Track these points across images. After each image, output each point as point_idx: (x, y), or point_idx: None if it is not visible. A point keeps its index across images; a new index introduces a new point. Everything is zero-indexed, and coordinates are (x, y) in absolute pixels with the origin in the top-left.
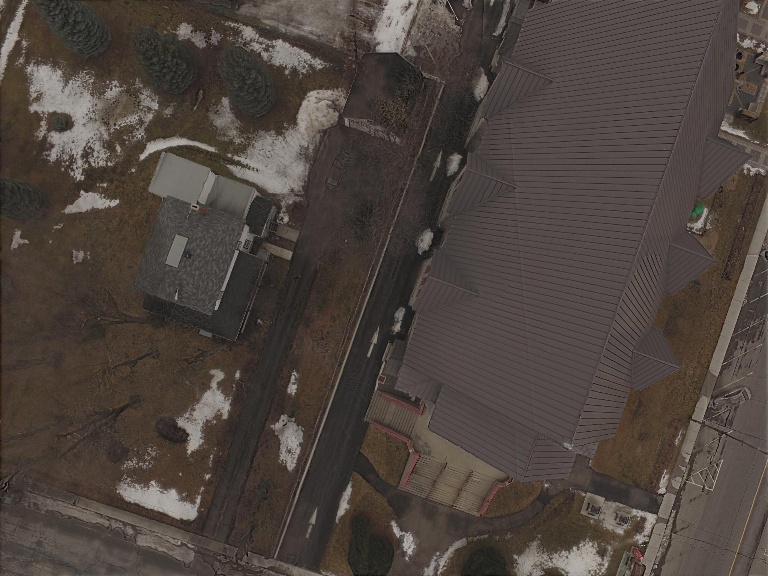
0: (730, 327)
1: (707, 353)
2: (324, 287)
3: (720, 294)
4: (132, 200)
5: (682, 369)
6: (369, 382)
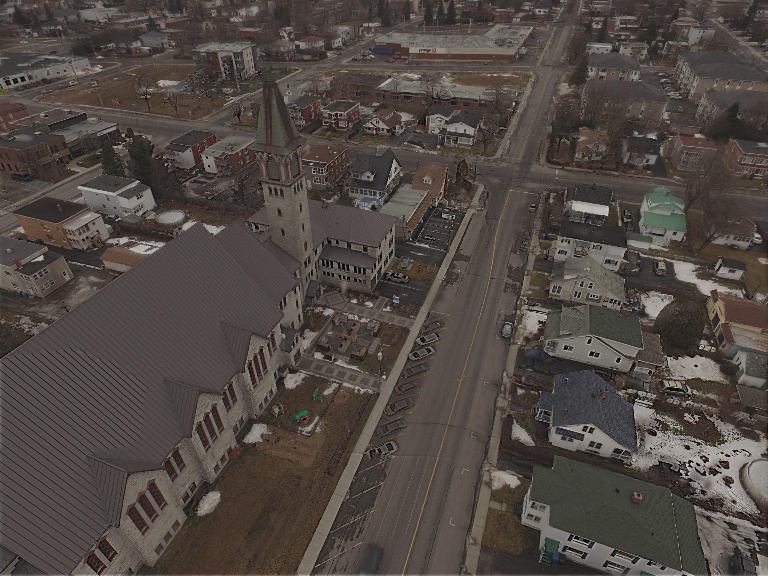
0: (327, 522)
1: (297, 551)
2: None
3: (321, 488)
4: None
5: (265, 570)
6: None
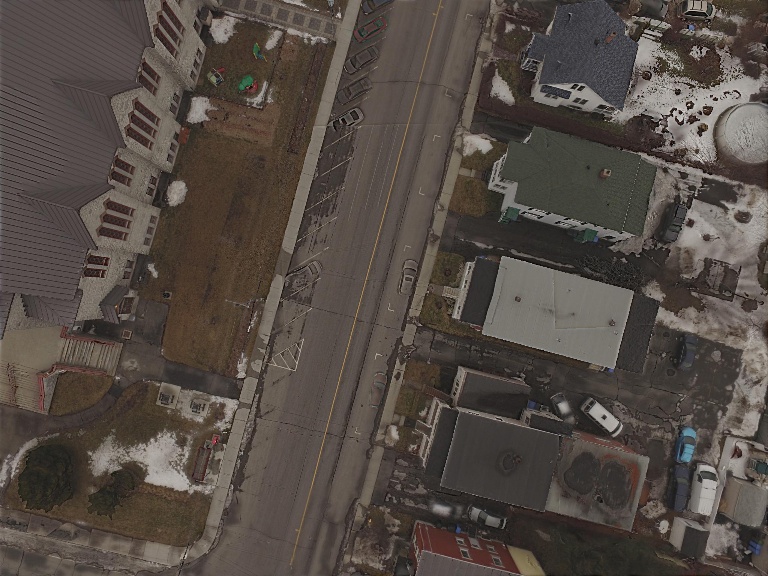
0: (301, 202)
1: (278, 230)
2: None
3: (287, 169)
4: None
5: (252, 248)
6: None
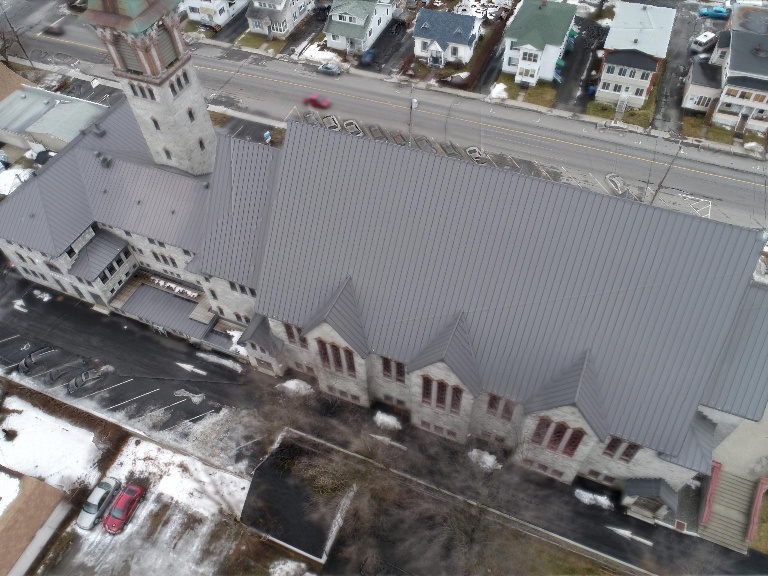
0: None
1: None
2: None
3: None
4: None
5: None
6: (689, 545)
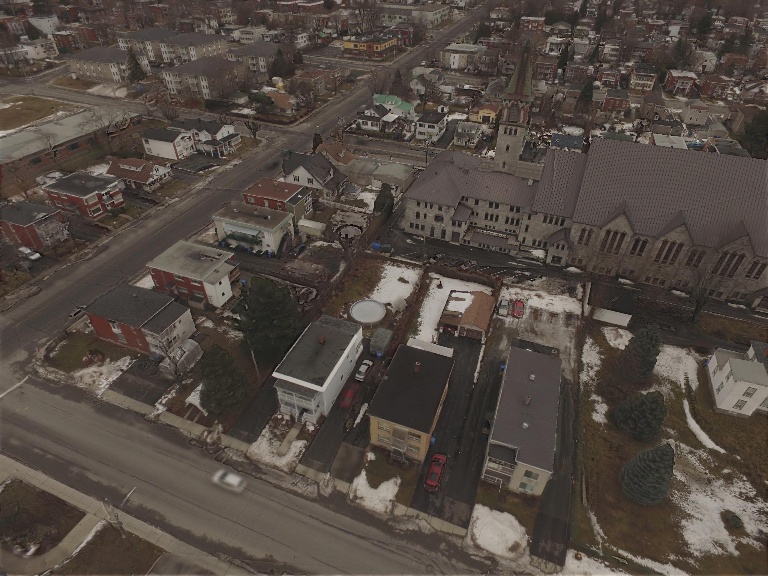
0: None
1: None
2: (744, 339)
3: None
4: (767, 456)
5: None
6: None
